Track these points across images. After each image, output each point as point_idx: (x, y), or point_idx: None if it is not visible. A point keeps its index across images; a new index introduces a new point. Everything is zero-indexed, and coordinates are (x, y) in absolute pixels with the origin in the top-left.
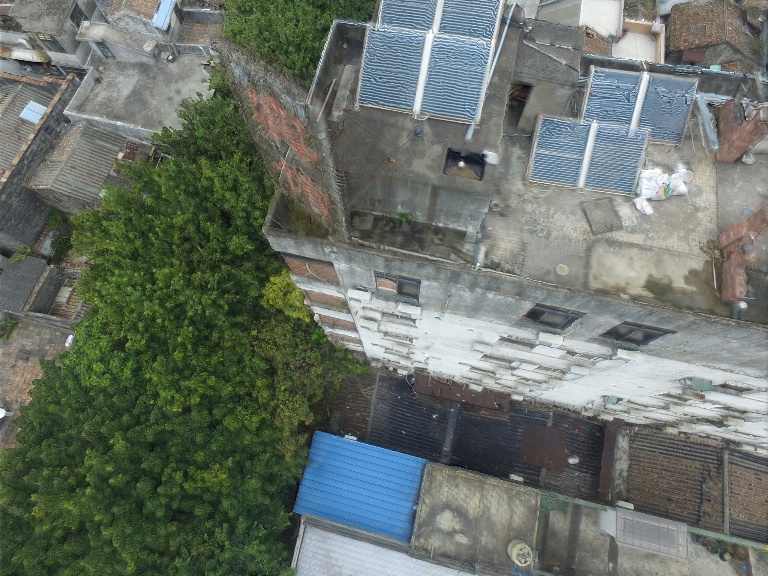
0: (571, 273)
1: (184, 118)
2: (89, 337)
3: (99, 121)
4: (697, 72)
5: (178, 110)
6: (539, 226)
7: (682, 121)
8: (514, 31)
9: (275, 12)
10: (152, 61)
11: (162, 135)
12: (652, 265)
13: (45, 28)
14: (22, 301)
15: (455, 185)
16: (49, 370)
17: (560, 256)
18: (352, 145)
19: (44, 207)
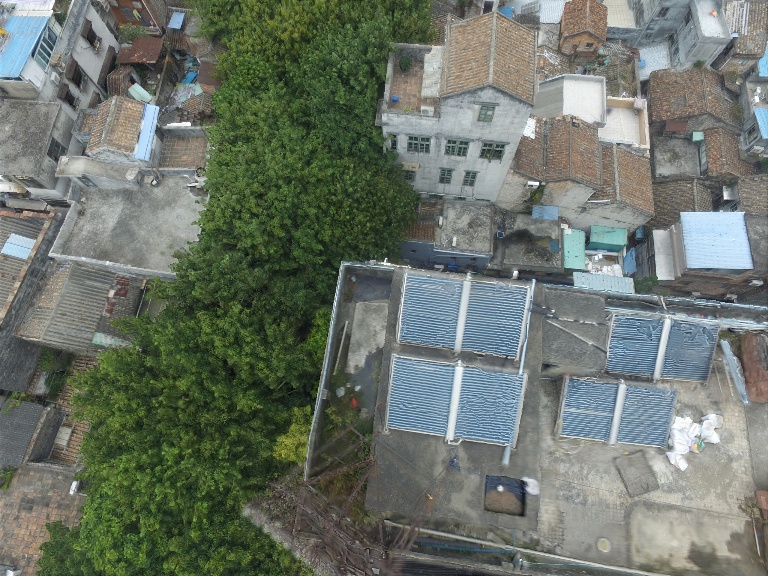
0: (613, 547)
1: (178, 271)
2: (99, 519)
3: (87, 262)
4: (716, 307)
5: (171, 265)
6: (574, 490)
7: (706, 358)
8: (537, 316)
9: (261, 144)
10: (136, 187)
11: (156, 286)
12: (693, 530)
13: (22, 170)
14: (21, 453)
15: (498, 525)
16: (57, 534)
17: (599, 526)
18: (386, 479)
19: (35, 348)
